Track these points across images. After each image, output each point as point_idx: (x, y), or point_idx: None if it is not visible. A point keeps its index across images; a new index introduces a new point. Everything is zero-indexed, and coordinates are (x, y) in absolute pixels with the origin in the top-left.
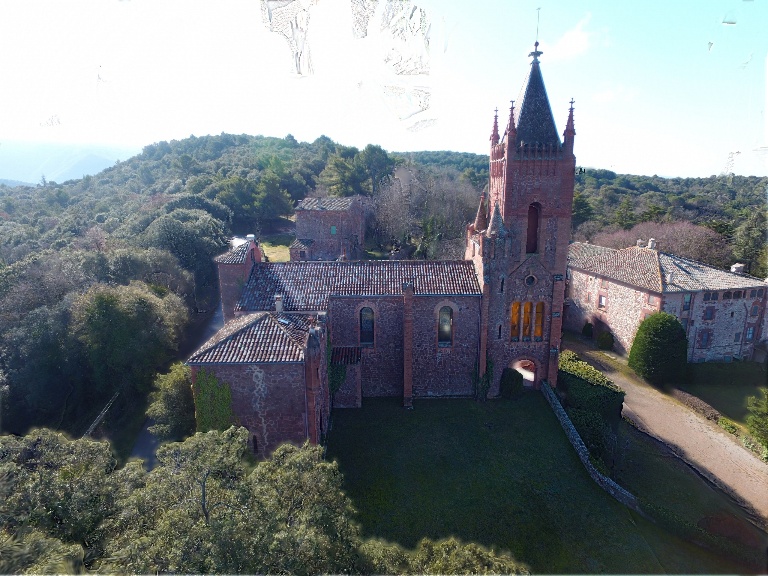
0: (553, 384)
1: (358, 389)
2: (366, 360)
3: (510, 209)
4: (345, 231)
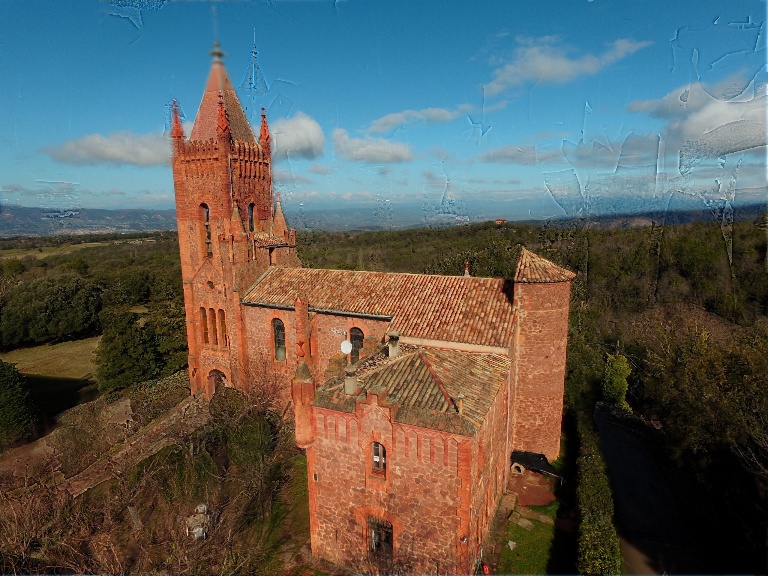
0: None
1: None
2: None
3: None
4: None
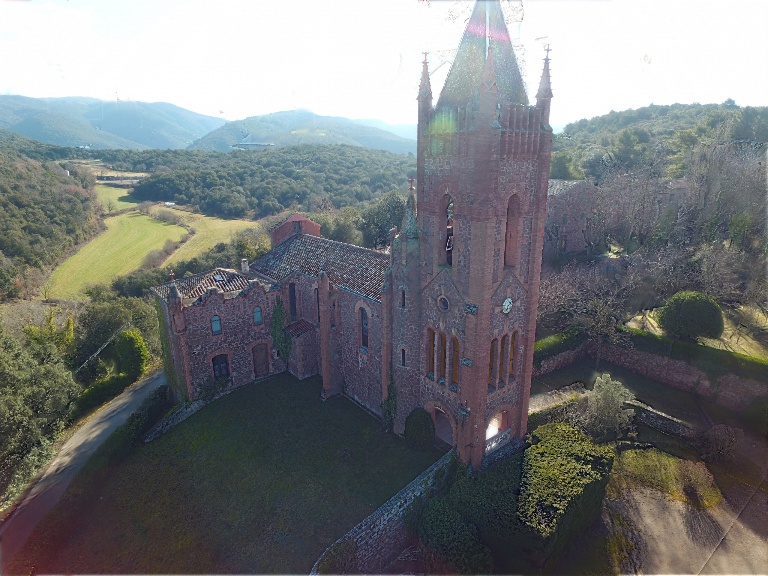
0: (462, 458)
1: (298, 362)
2: (319, 340)
3: (422, 202)
4: (552, 220)
